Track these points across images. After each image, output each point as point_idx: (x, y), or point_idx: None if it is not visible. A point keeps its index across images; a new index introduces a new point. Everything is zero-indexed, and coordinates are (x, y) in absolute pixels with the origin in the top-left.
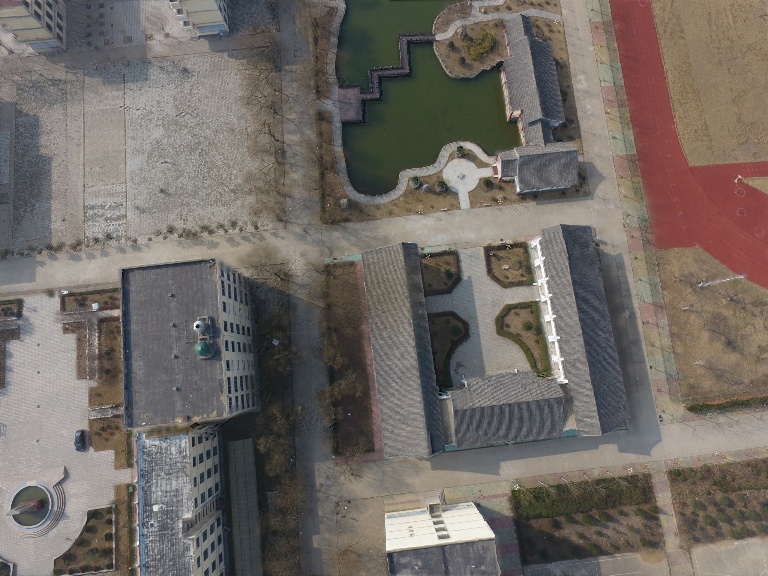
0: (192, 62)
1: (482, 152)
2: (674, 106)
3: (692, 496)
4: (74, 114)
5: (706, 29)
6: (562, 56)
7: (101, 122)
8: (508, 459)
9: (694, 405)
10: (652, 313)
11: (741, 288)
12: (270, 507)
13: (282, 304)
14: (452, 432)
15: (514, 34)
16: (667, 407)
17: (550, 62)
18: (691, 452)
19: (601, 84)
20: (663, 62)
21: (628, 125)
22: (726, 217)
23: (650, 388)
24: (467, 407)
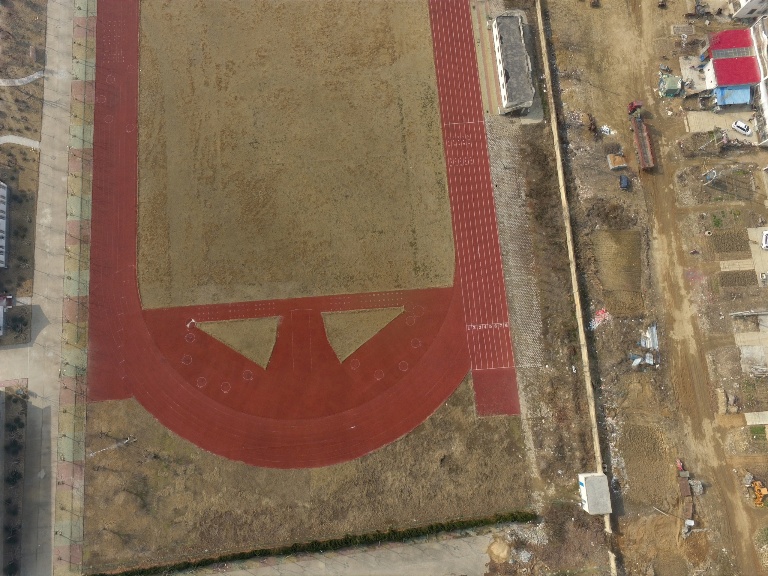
0: None
1: None
2: (140, 242)
3: None
4: None
5: (191, 157)
6: (31, 187)
7: None
8: None
9: None
10: (69, 473)
11: (169, 444)
12: None
13: None
14: None
15: None
16: None
17: None
18: None
19: (67, 218)
20: (137, 194)
21: (86, 264)
22: (170, 365)
23: (50, 556)
24: None
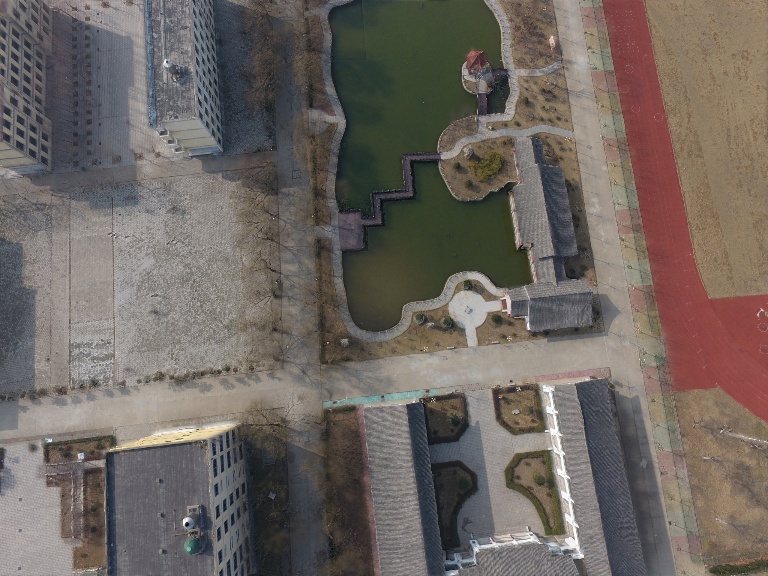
0: (184, 184)
1: (490, 283)
2: (692, 232)
3: None
4: (59, 242)
5: (725, 147)
6: (574, 177)
7: (88, 251)
8: None
9: (716, 567)
10: (671, 462)
11: (765, 434)
12: None
13: (279, 453)
14: None
15: (524, 158)
16: (688, 568)
17: (562, 189)
18: None
19: (615, 208)
20: (680, 183)
21: (644, 253)
22: (748, 355)
23: (669, 547)
24: None
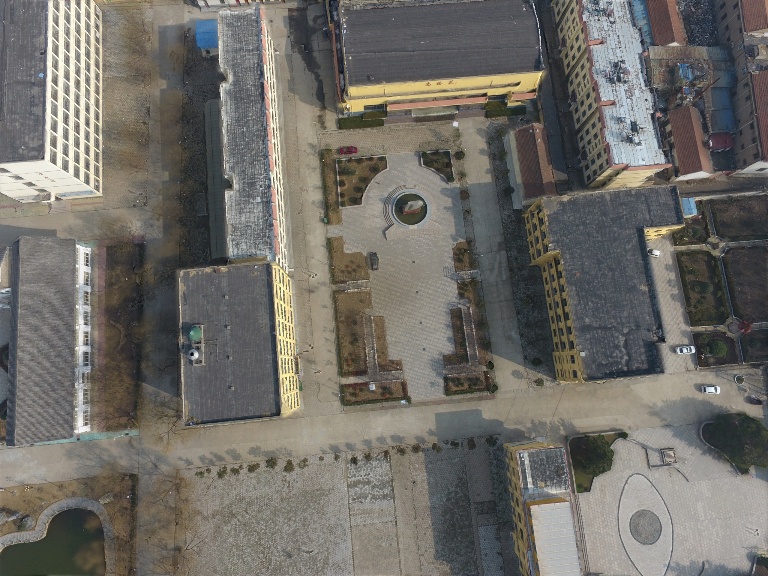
0: None
1: None
2: None
3: None
4: None
5: None
6: None
7: None
8: None
9: None
10: None
11: None
12: (205, 203)
13: None
14: (8, 258)
15: None
16: None
17: None
18: None
19: None
20: None
21: None
22: None
23: None
24: None
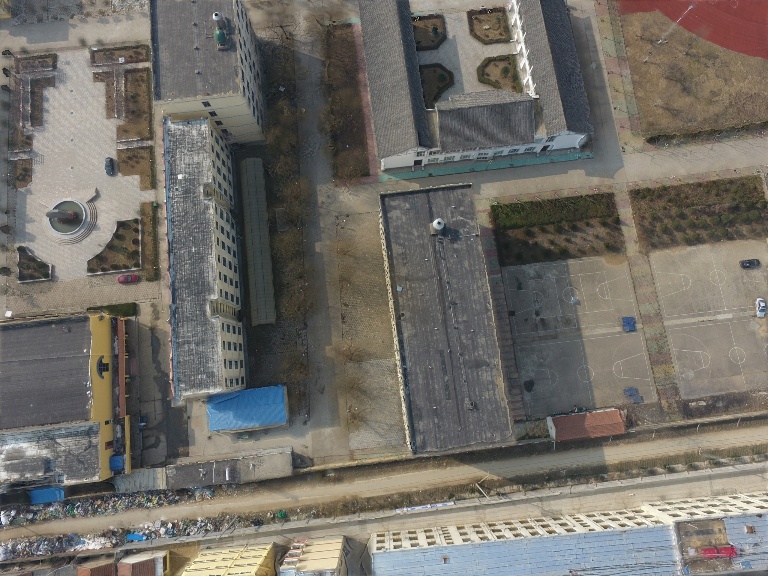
0: None
1: None
2: None
3: (650, 210)
4: None
5: None
6: None
7: None
8: (488, 182)
9: (652, 136)
10: (616, 65)
11: (696, 44)
12: (278, 220)
13: (287, 58)
14: (437, 138)
15: None
16: (629, 140)
17: None
18: (650, 176)
19: None
20: None
21: None
22: None
23: (614, 125)
24: (450, 109)
